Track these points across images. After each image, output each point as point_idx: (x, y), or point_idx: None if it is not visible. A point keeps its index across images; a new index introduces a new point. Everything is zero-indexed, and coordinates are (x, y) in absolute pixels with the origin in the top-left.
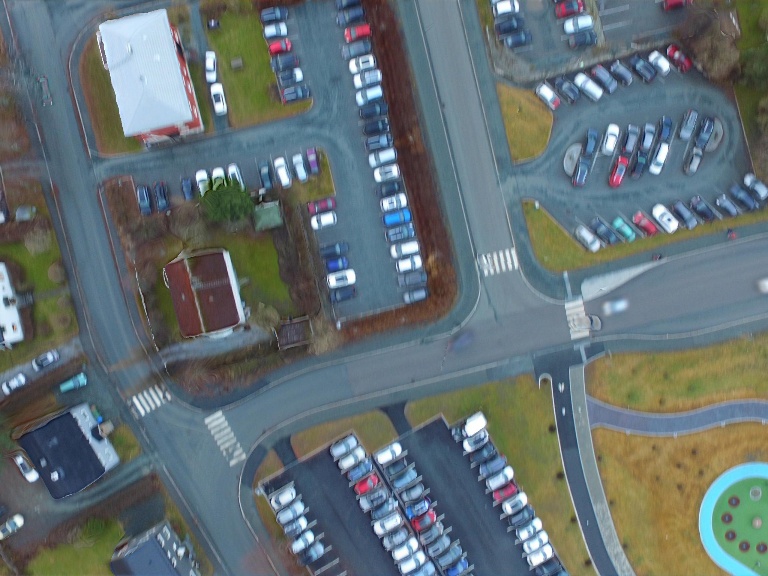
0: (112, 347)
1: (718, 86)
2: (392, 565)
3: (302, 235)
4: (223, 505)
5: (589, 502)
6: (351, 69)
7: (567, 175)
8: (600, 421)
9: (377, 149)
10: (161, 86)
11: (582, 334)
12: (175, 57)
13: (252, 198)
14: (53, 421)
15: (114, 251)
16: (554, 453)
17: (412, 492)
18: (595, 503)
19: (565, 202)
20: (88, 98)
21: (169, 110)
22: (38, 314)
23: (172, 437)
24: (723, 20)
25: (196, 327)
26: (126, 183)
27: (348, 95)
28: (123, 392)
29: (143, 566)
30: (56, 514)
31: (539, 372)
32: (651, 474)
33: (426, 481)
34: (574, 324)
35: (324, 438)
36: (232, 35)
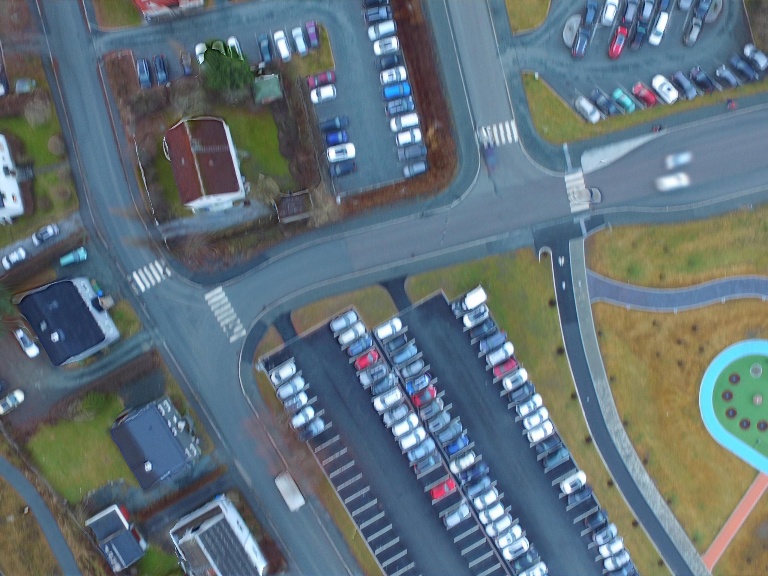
0: (112, 222)
1: None
2: (392, 442)
3: (302, 109)
4: (223, 381)
5: (589, 378)
6: None
7: (567, 46)
8: (600, 295)
9: (377, 21)
10: None
11: (582, 207)
12: None
13: (252, 71)
14: (53, 286)
15: (114, 126)
16: (554, 328)
17: (412, 367)
18: (595, 379)
19: (565, 74)
20: None
21: None
22: (38, 189)
23: (172, 313)
24: None
25: (196, 191)
26: (126, 57)
27: None
28: (123, 267)
29: (143, 431)
30: (56, 390)
31: (539, 245)
32: (651, 350)
33: (426, 357)
34: (574, 197)
35: (324, 314)
36: None
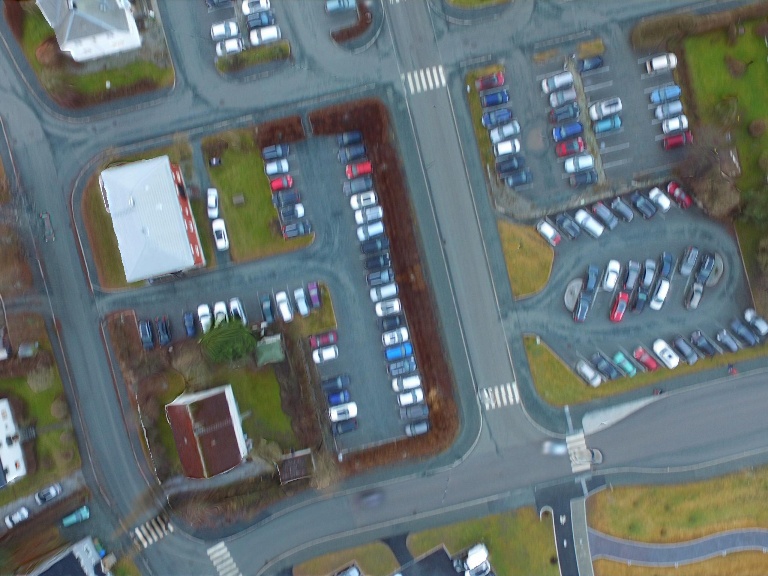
0: (114, 479)
1: (718, 222)
2: None
3: (304, 369)
4: None
5: None
6: (352, 205)
7: (568, 310)
8: (601, 552)
9: (378, 285)
10: (163, 235)
11: (583, 467)
12: (177, 203)
13: (254, 332)
14: (56, 565)
15: (116, 384)
16: None
17: None
18: None
19: (566, 336)
20: (90, 234)
21: (171, 258)
22: (41, 447)
23: (174, 568)
24: (723, 158)
25: (198, 471)
26: (128, 317)
27: (349, 229)
28: (126, 524)
29: None
30: None
31: (540, 505)
32: None
33: None
34: (575, 457)
35: (326, 569)
36: (234, 171)
